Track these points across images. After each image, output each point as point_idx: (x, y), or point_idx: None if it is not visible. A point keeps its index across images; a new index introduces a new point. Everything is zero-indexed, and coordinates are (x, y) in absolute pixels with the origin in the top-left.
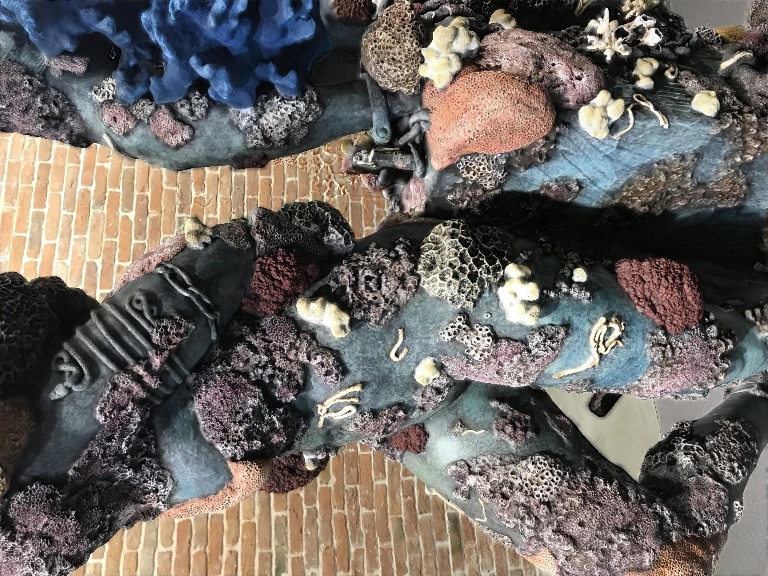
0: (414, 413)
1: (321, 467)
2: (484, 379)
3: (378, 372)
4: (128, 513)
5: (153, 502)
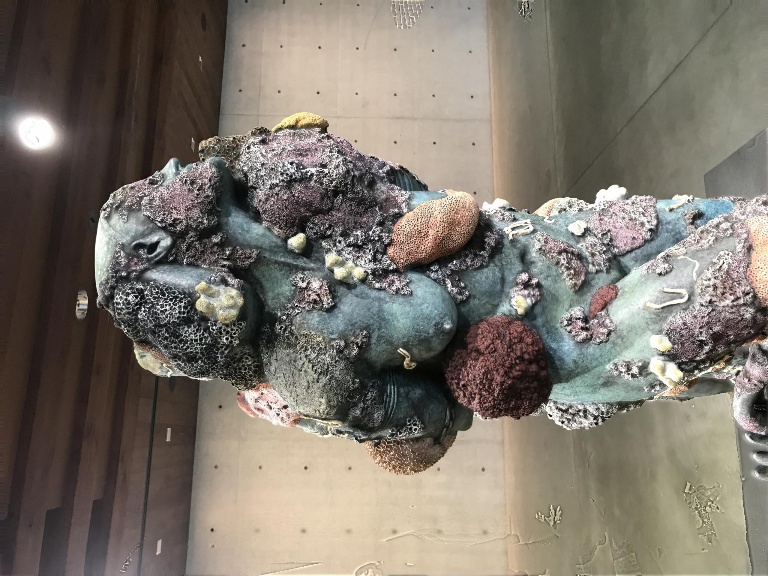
0: (590, 266)
1: (537, 340)
2: (624, 231)
3: (540, 223)
4: (382, 191)
5: (398, 195)
